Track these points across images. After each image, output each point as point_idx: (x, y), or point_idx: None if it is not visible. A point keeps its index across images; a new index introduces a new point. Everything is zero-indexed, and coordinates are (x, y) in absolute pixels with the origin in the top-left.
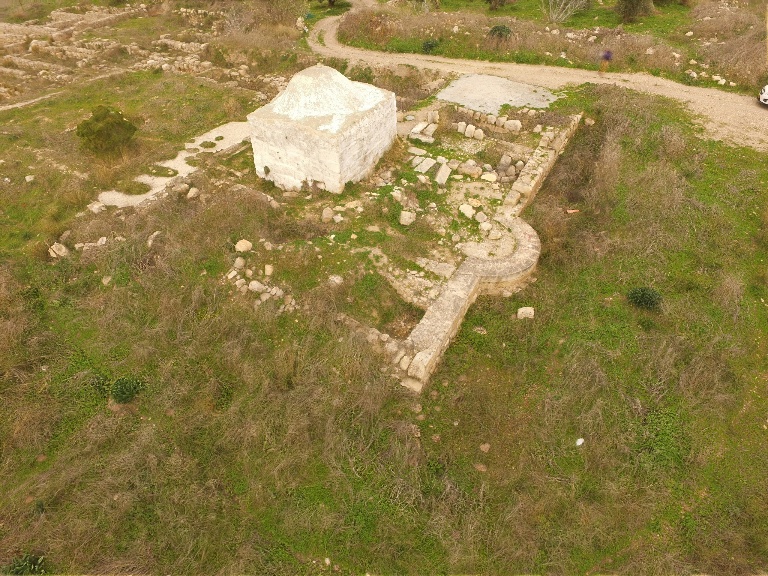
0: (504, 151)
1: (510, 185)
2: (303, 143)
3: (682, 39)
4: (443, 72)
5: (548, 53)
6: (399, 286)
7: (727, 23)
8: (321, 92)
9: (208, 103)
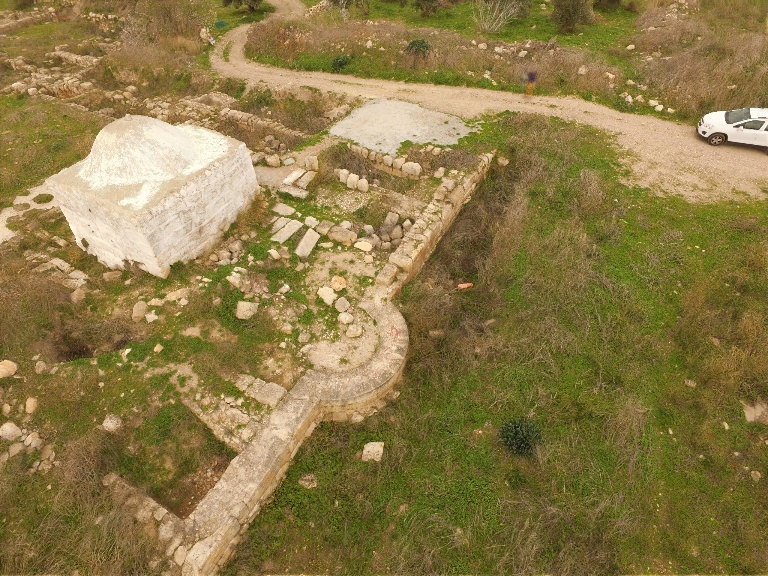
0: (391, 206)
1: (389, 255)
2: (107, 219)
3: (622, 54)
4: (349, 96)
5: (470, 73)
6: (207, 421)
7: (672, 34)
8: (127, 153)
9: (64, 140)
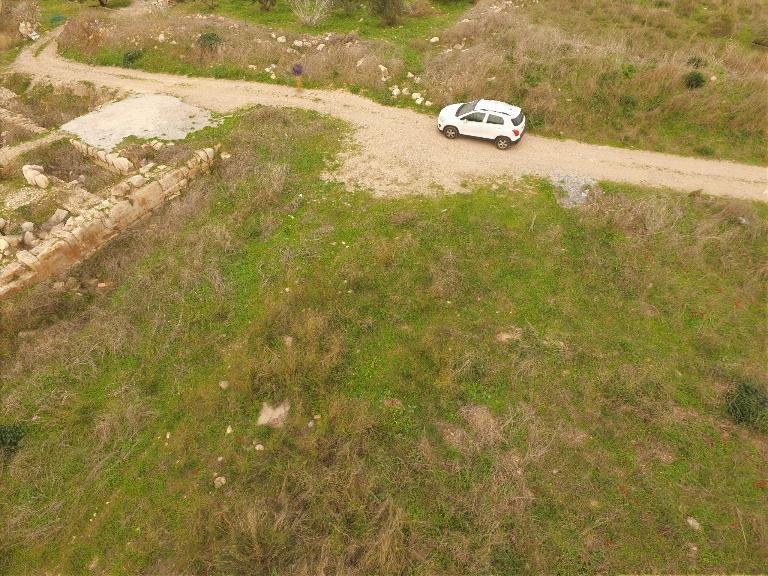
0: (63, 203)
1: None
2: None
3: (420, 46)
4: (121, 91)
5: (251, 66)
6: None
7: (478, 27)
8: None
9: None
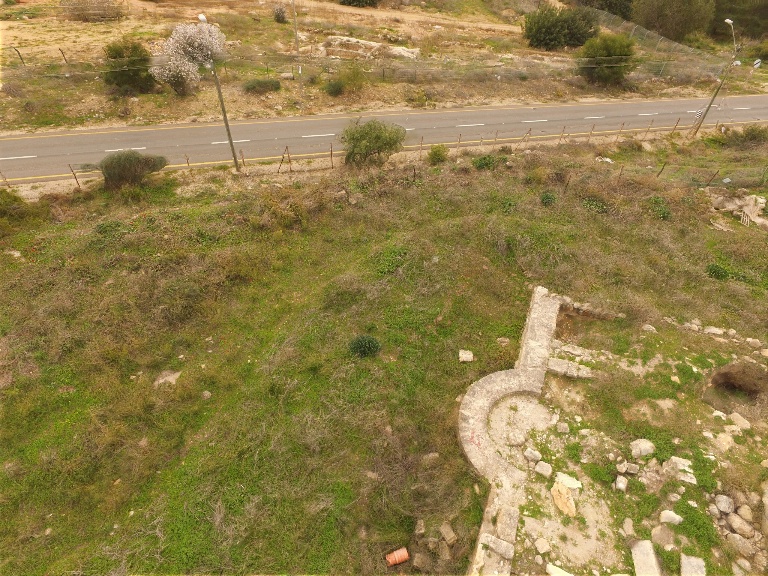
0: None
1: (517, 566)
2: None
3: None
4: None
5: None
6: None
7: None
8: None
9: None
